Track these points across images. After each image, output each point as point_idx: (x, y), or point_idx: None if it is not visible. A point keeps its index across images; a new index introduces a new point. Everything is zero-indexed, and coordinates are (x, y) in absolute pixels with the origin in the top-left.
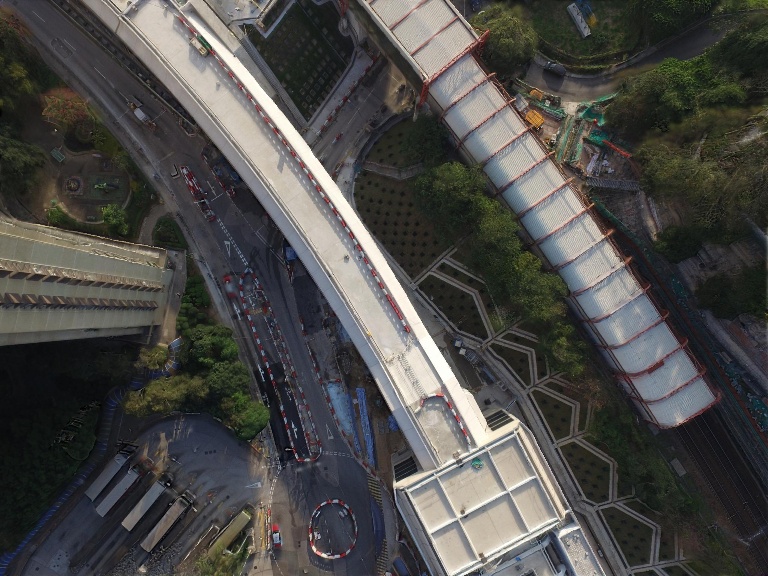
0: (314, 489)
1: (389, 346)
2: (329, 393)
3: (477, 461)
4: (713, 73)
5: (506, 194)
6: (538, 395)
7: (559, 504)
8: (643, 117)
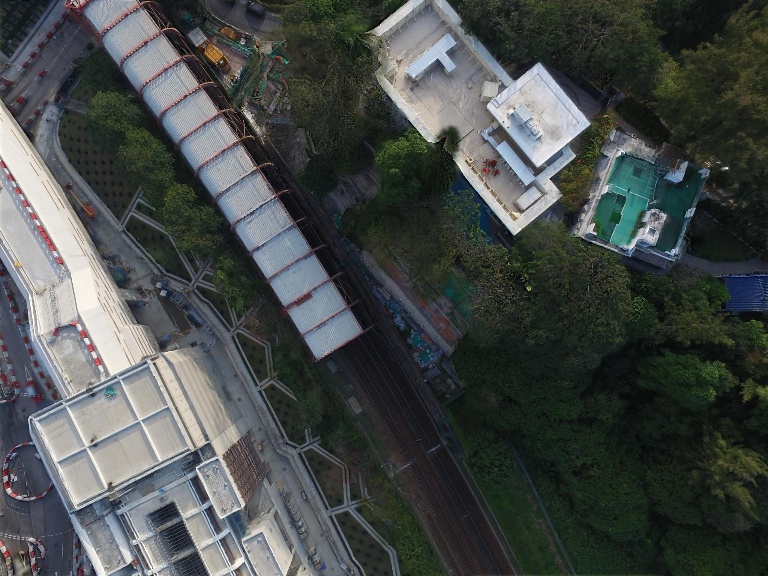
0: (11, 431)
1: (41, 278)
2: (28, 334)
3: (110, 390)
4: (353, 3)
5: (164, 125)
6: (240, 337)
7: (197, 435)
8: (294, 48)
